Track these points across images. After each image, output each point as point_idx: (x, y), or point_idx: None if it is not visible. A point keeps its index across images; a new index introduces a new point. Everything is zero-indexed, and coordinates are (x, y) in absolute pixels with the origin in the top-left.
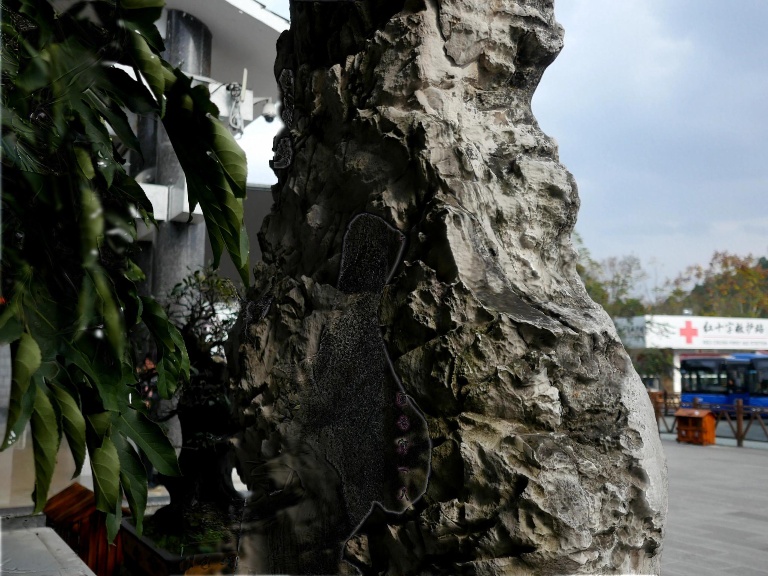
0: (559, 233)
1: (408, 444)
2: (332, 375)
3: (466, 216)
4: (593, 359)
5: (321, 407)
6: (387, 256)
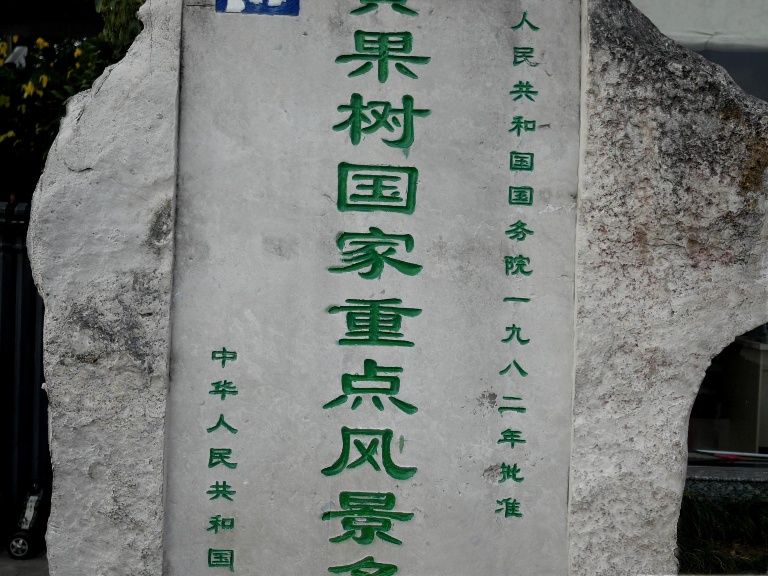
0: None
1: (503, 260)
2: None
3: None
4: None
5: None
6: None
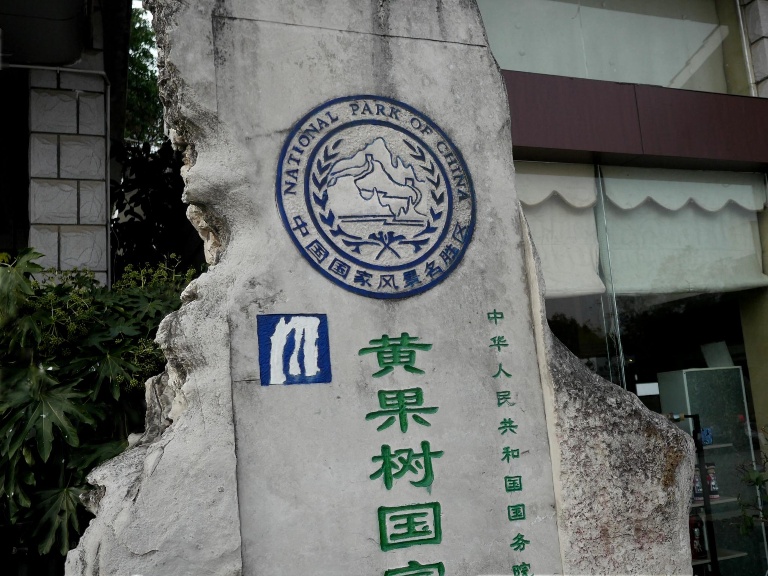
0: (184, 372)
1: (511, 569)
2: (688, 468)
3: (150, 381)
4: (99, 498)
5: (691, 510)
6: (531, 333)
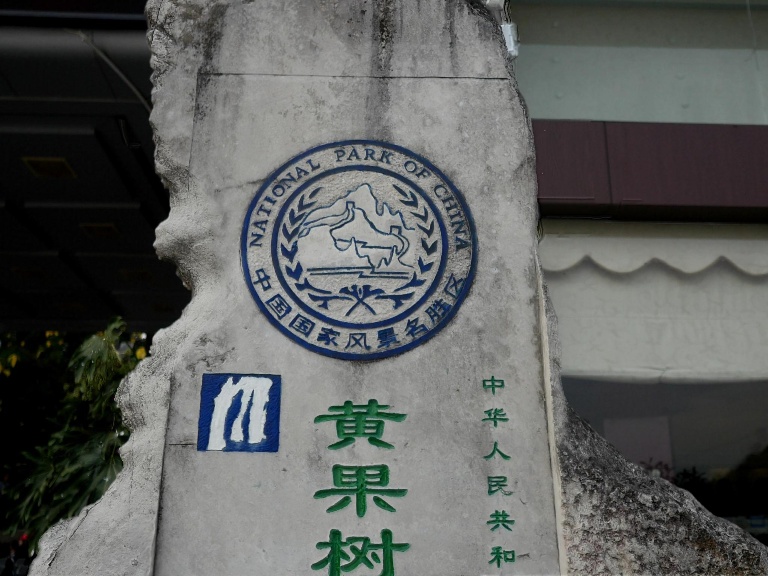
0: None
1: None
2: None
3: None
4: None
5: None
6: (541, 406)
